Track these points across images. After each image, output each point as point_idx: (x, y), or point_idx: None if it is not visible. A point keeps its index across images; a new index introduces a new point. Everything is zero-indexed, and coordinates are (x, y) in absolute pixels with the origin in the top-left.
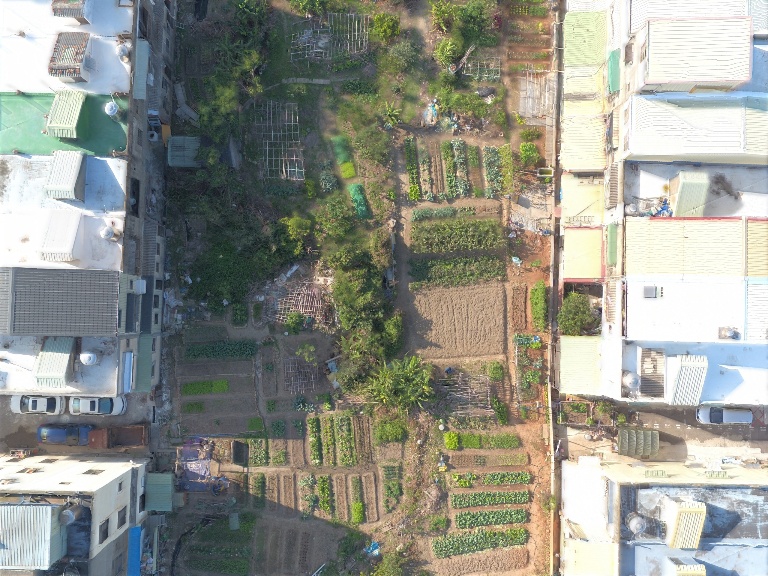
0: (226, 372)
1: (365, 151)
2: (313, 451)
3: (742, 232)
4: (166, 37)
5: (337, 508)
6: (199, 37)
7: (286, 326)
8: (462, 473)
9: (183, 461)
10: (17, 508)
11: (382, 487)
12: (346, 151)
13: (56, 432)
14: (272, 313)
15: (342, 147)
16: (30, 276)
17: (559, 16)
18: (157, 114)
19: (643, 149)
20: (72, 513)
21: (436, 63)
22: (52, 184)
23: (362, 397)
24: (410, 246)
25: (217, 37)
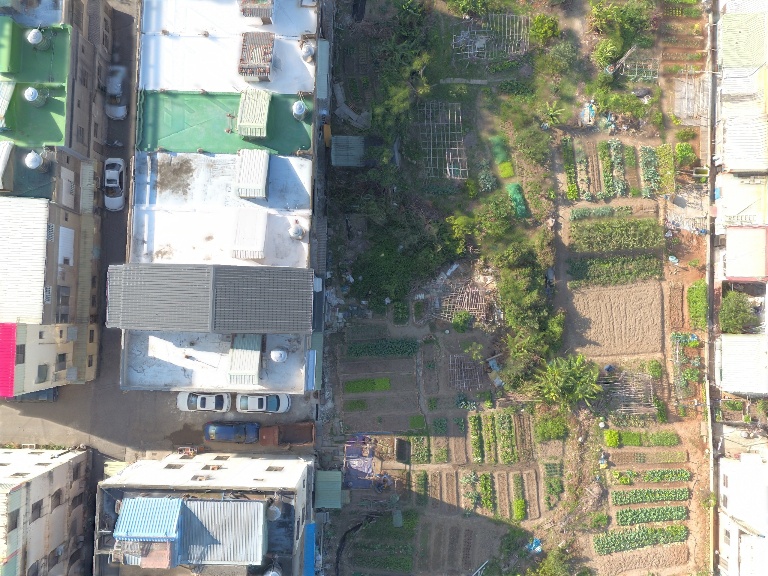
0: (388, 370)
1: (527, 151)
2: (475, 448)
3: None
4: None
5: (499, 505)
6: (357, 38)
7: (455, 324)
8: (622, 470)
9: (346, 458)
10: (230, 503)
11: (543, 484)
12: (504, 151)
13: (223, 429)
14: (433, 311)
15: (501, 147)
16: (230, 273)
17: (712, 18)
18: (325, 113)
19: None
20: (278, 509)
21: (592, 64)
22: (243, 182)
23: (528, 395)
24: (569, 245)
25: (376, 38)
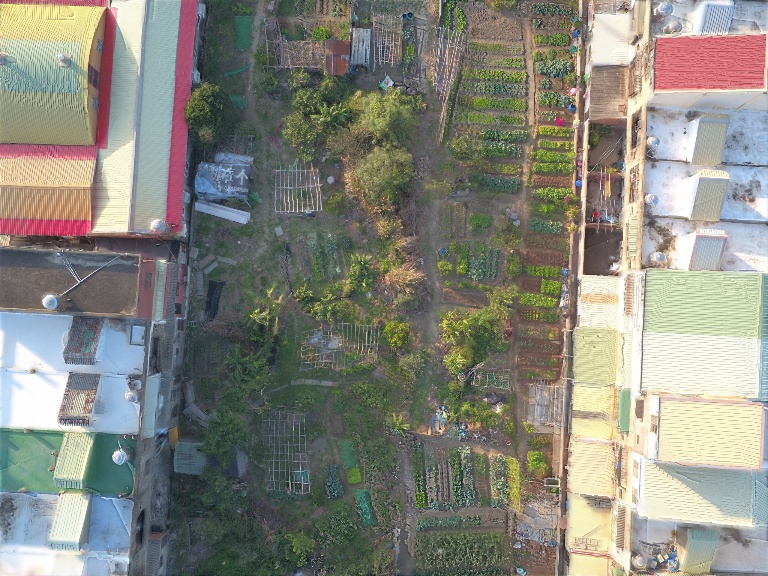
0: None
1: (371, 465)
2: None
3: None
4: (176, 347)
5: None
6: (209, 336)
7: None
8: None
9: None
10: None
11: None
12: (352, 456)
13: None
14: None
15: (349, 453)
16: None
17: (569, 322)
18: (164, 429)
19: (651, 516)
20: None
21: (445, 368)
22: (57, 536)
23: None
24: (414, 556)
25: (227, 337)
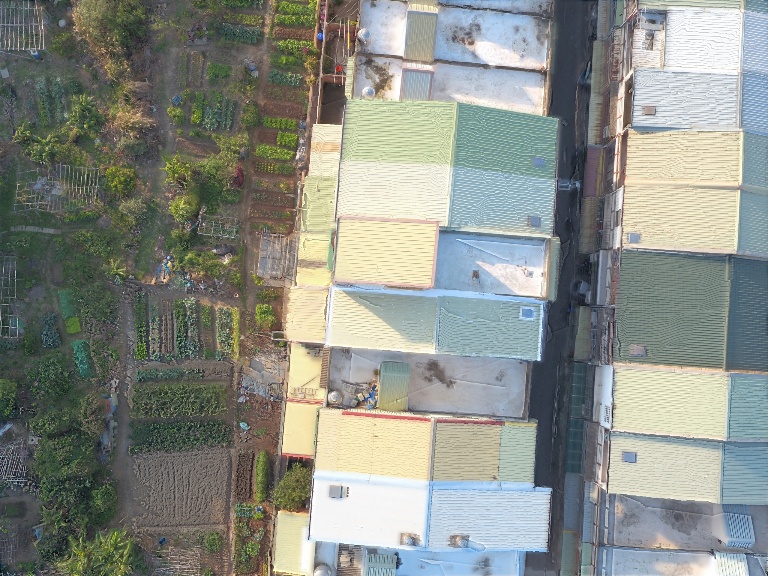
0: None
1: (85, 310)
2: None
3: (430, 435)
4: None
5: None
6: None
7: None
8: None
9: None
10: None
11: None
12: (72, 305)
13: None
14: None
15: (67, 301)
16: None
17: (305, 176)
18: None
19: (336, 343)
20: None
21: (174, 218)
22: None
23: (61, 571)
24: None
25: None
